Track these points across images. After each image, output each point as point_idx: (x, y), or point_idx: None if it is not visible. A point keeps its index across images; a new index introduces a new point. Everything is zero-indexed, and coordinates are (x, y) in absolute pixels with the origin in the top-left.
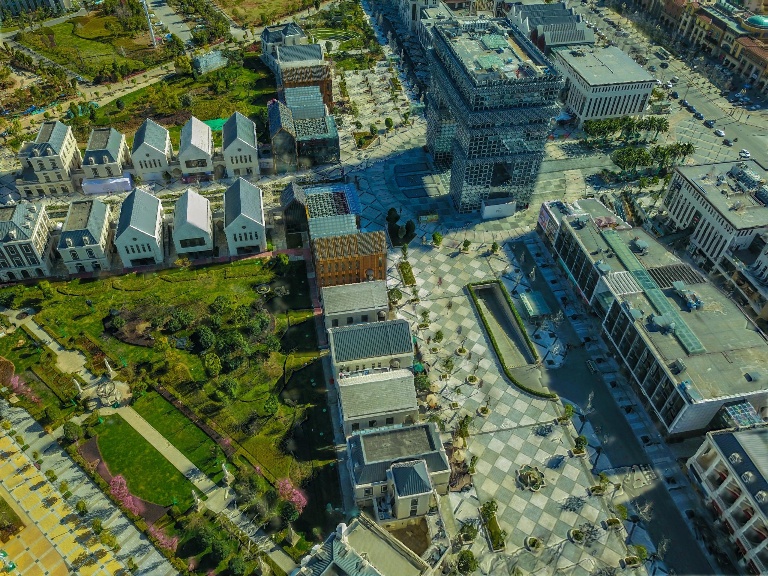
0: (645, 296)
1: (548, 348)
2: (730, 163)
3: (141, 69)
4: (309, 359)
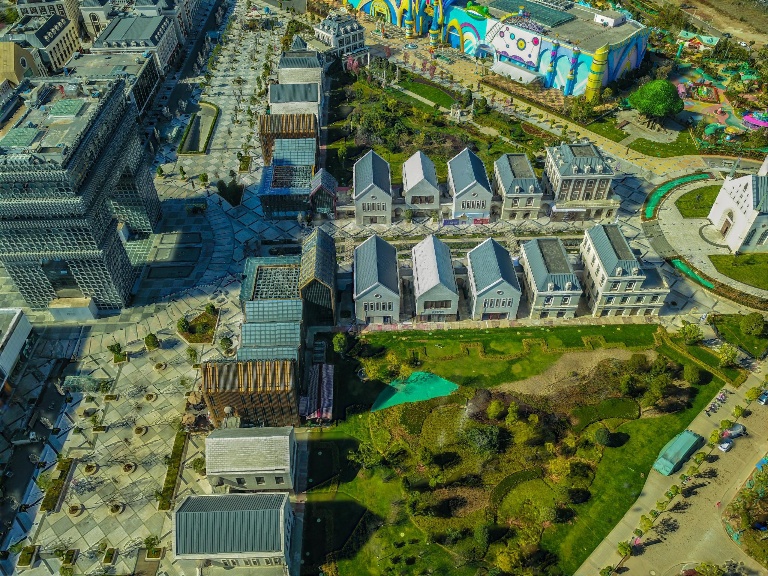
0: None
1: (181, 122)
2: None
3: None
4: (335, 124)
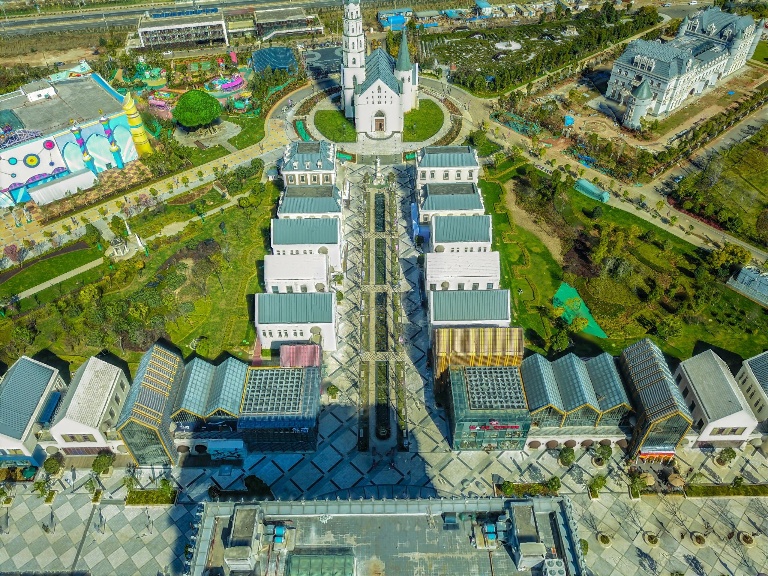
0: None
1: None
2: None
3: (728, 226)
4: None
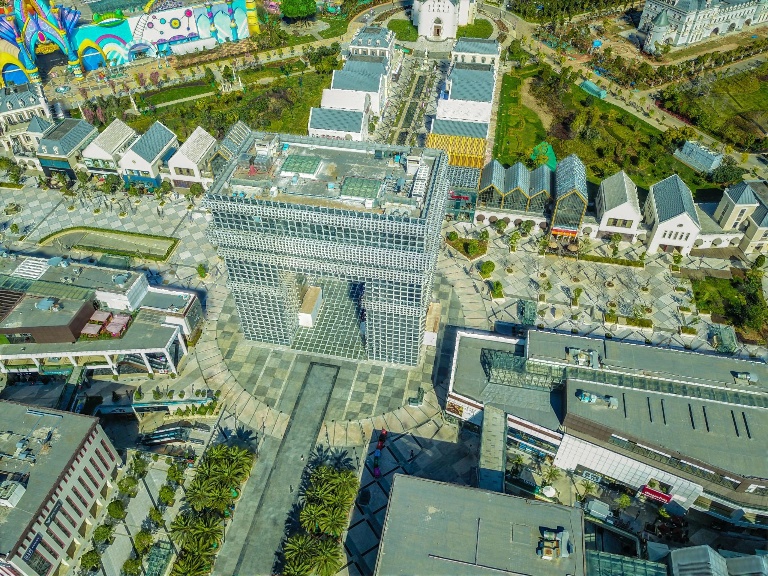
0: (5, 275)
1: None
2: (37, 506)
3: (698, 123)
4: None
